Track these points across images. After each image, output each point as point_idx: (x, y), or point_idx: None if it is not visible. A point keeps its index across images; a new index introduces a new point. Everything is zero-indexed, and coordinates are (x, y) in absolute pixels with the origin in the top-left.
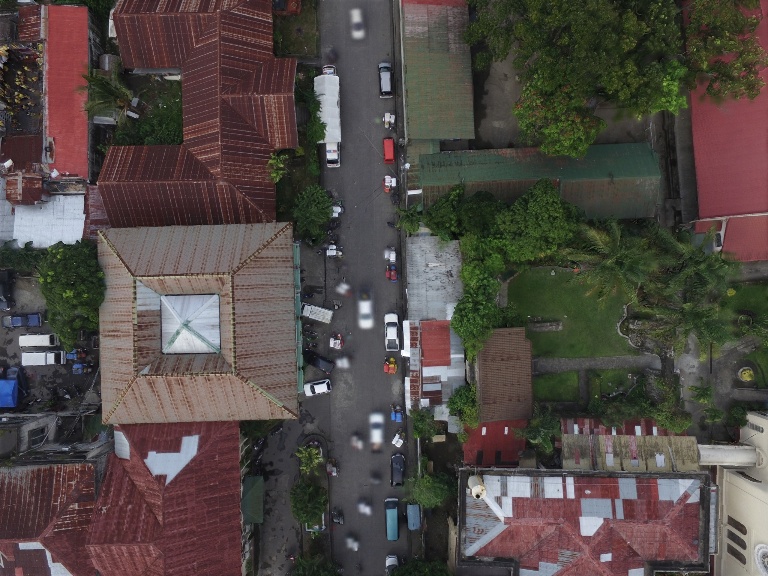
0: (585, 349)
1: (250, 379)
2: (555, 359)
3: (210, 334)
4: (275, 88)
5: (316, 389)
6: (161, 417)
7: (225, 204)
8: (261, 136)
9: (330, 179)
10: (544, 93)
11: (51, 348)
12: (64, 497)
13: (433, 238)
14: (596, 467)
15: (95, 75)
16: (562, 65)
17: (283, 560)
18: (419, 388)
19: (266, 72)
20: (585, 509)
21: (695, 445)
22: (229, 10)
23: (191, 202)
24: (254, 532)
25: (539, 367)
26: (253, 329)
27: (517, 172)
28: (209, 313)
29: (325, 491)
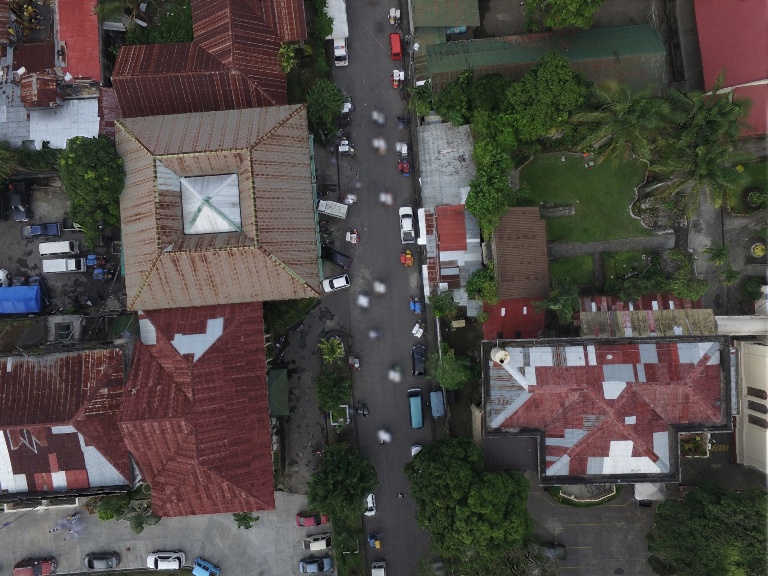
0: (598, 233)
1: (272, 253)
2: (569, 244)
3: (231, 212)
4: None
5: (335, 283)
6: (185, 300)
7: (238, 96)
8: (270, 28)
9: (339, 79)
10: None
11: (71, 256)
12: (94, 382)
13: (444, 125)
14: None
15: None
16: None
17: (310, 456)
18: (437, 274)
19: None
20: (607, 374)
21: (712, 316)
22: None
23: (204, 95)
24: (280, 430)
25: (554, 252)
26: (273, 205)
27: (524, 56)
28: (229, 191)
29: (349, 377)
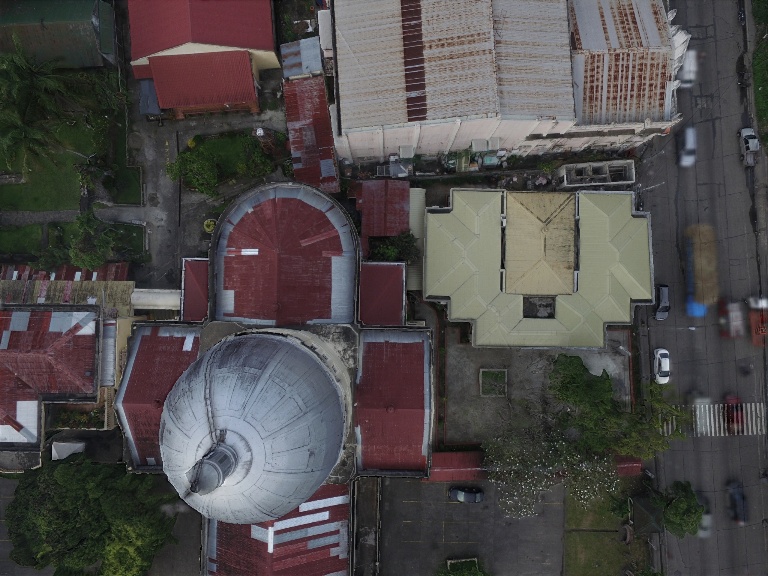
0: (49, 202)
1: None
2: (19, 213)
3: None
4: None
5: None
6: None
7: None
8: None
9: None
10: None
11: None
12: None
13: None
14: None
15: None
16: None
17: None
18: None
19: None
20: None
21: (131, 289)
22: None
23: None
24: None
25: (3, 221)
26: None
27: None
28: None
29: None
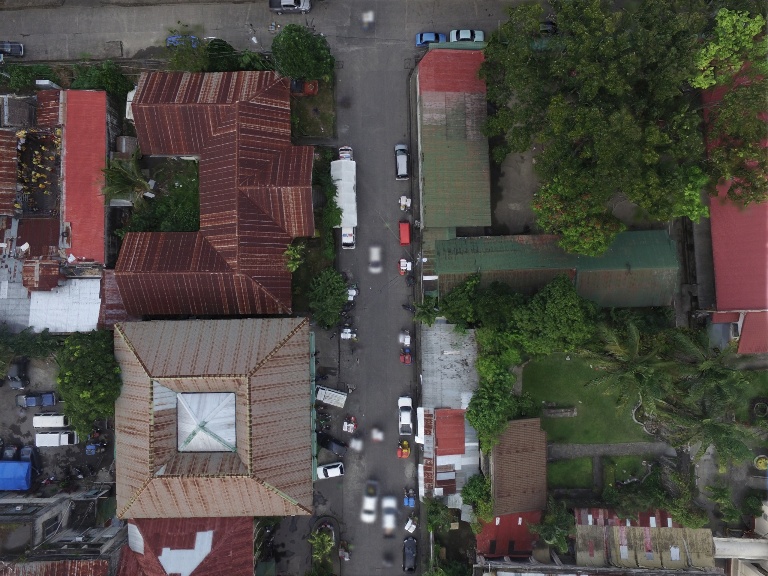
0: (599, 435)
1: (266, 480)
2: (569, 445)
3: (226, 433)
4: (293, 180)
5: (329, 473)
6: (176, 513)
7: (241, 294)
8: (278, 225)
9: (345, 260)
10: (564, 199)
11: (65, 428)
12: None
13: (448, 326)
14: (610, 560)
15: (112, 158)
16: (584, 179)
17: None
18: (433, 476)
19: (283, 161)
20: None
21: (710, 538)
22: (247, 101)
23: (207, 291)
24: None
25: (553, 453)
26: (269, 429)
27: (534, 261)
28: (225, 412)
29: None
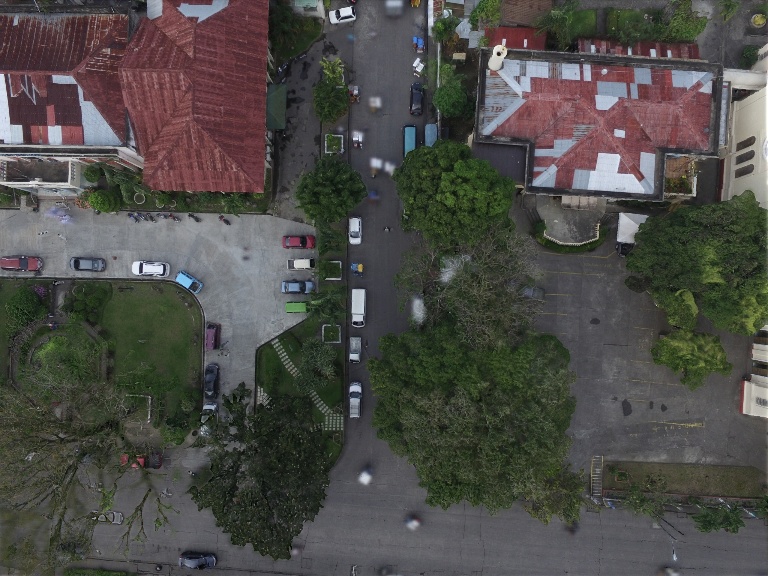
0: None
1: None
2: None
3: None
4: None
5: (341, 12)
6: None
7: None
8: None
9: None
10: None
11: None
12: (97, 41)
13: None
14: None
15: None
16: None
17: None
18: (442, 3)
19: None
20: (601, 89)
21: None
22: None
23: None
24: (274, 156)
25: None
26: None
27: None
28: None
29: None
